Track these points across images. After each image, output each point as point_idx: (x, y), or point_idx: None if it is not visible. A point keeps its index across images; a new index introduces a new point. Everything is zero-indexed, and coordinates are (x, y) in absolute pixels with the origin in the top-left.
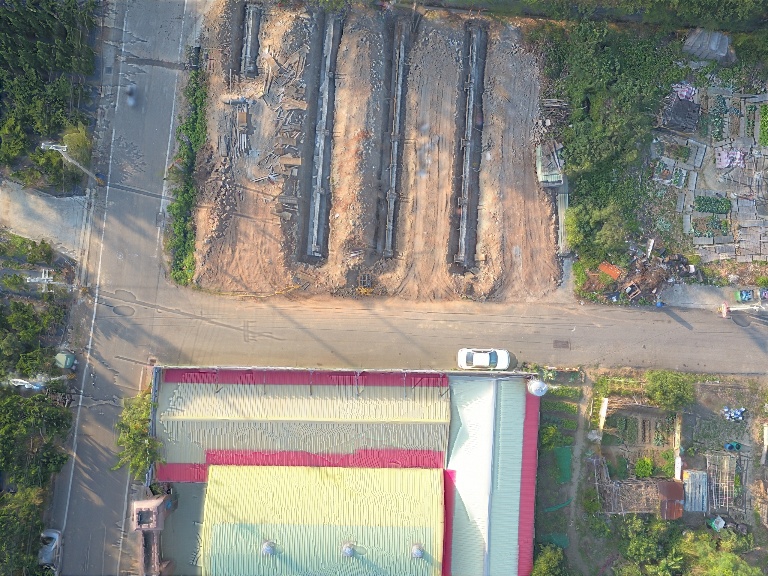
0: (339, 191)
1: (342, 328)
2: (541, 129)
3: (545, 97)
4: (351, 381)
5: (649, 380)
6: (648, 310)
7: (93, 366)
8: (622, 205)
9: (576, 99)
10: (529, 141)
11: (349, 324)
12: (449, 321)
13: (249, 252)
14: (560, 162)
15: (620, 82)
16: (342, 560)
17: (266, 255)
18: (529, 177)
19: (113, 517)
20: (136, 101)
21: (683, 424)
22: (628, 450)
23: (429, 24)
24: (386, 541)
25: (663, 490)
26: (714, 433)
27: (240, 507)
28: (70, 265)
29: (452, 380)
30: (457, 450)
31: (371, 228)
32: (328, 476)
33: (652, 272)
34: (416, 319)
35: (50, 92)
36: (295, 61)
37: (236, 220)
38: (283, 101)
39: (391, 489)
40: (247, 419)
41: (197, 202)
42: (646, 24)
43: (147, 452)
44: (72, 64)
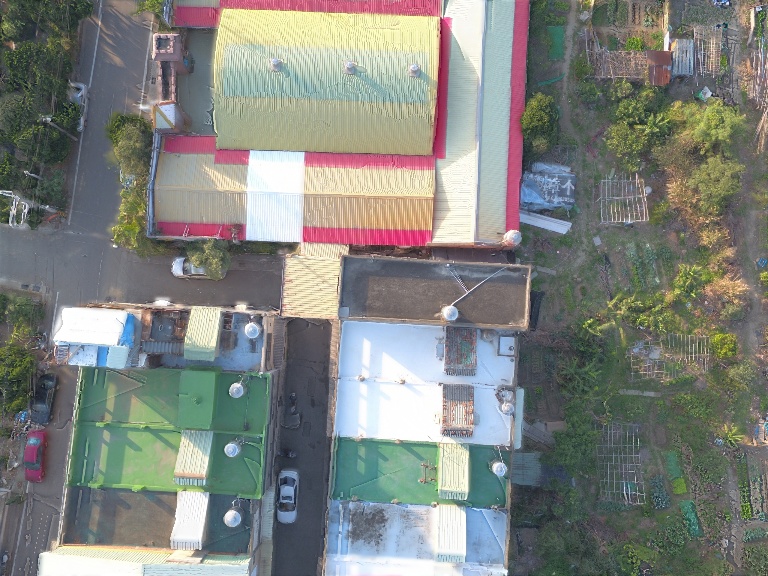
0: None
1: None
2: None
3: None
4: None
5: None
6: None
7: None
8: None
9: None
10: None
11: None
12: None
13: None
14: None
15: None
16: None
17: None
18: None
19: (134, 80)
20: None
21: (672, 9)
22: (618, 31)
23: None
24: (385, 69)
25: (651, 56)
26: (702, 18)
27: (250, 33)
28: None
29: None
30: None
31: None
32: (332, 17)
33: None
34: None
35: None
36: None
37: None
38: None
39: None
40: None
41: None
42: None
43: None
44: None
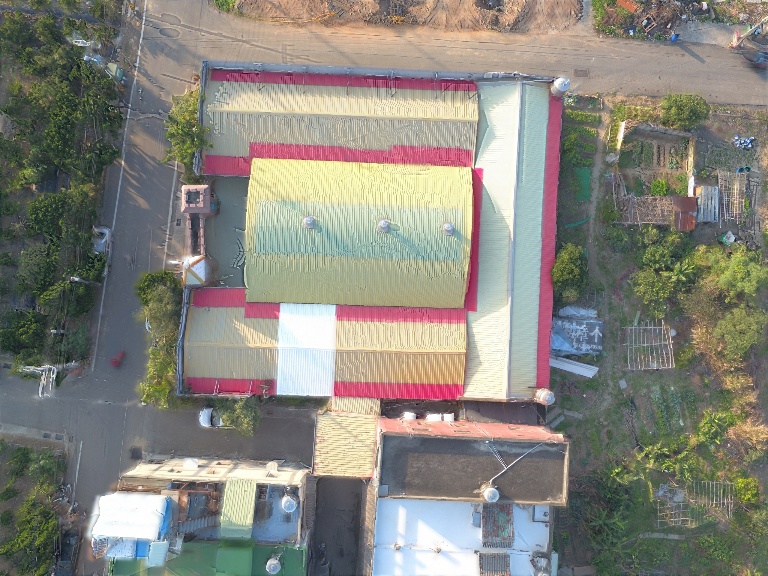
0: None
1: (375, 53)
2: None
3: None
4: (385, 84)
5: (664, 102)
6: (663, 44)
7: (140, 82)
8: None
9: None
10: None
11: (381, 49)
12: (475, 49)
13: None
14: None
15: None
16: None
17: None
18: None
19: (159, 221)
20: None
21: (696, 150)
22: (644, 173)
23: None
24: (418, 224)
25: (677, 202)
26: (725, 160)
27: (282, 188)
28: None
29: (480, 86)
30: (484, 150)
31: None
32: (363, 168)
33: (667, 7)
34: (444, 46)
35: None
36: None
37: None
38: None
39: (421, 191)
40: (288, 112)
41: None
42: None
43: None
44: None
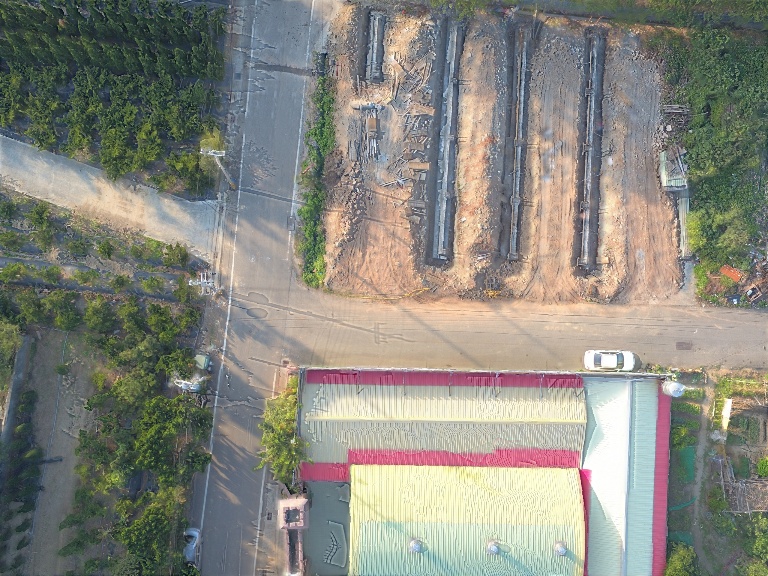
0: (465, 195)
1: (470, 330)
2: (662, 134)
3: (666, 103)
4: (488, 382)
5: None
6: (767, 312)
7: (228, 367)
8: (742, 209)
9: (698, 105)
10: (651, 146)
11: (477, 326)
12: (574, 323)
13: (379, 255)
14: (684, 167)
15: (741, 88)
16: (485, 558)
17: (396, 258)
18: (651, 182)
19: (249, 516)
20: (265, 106)
21: None
22: (750, 450)
23: (551, 31)
24: (527, 539)
25: None
26: None
27: (386, 506)
28: (203, 268)
29: (586, 381)
30: (592, 450)
31: (497, 232)
32: (468, 475)
33: None
34: (542, 321)
35: (185, 98)
36: (422, 67)
37: (366, 224)
38: (411, 107)
39: (525, 488)
40: (389, 419)
41: (326, 206)
42: (764, 31)
43: (293, 452)
44: (207, 70)
